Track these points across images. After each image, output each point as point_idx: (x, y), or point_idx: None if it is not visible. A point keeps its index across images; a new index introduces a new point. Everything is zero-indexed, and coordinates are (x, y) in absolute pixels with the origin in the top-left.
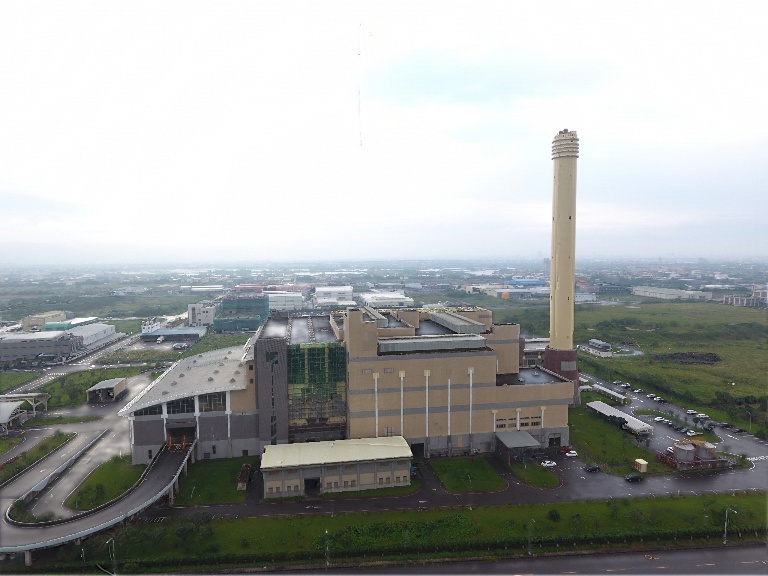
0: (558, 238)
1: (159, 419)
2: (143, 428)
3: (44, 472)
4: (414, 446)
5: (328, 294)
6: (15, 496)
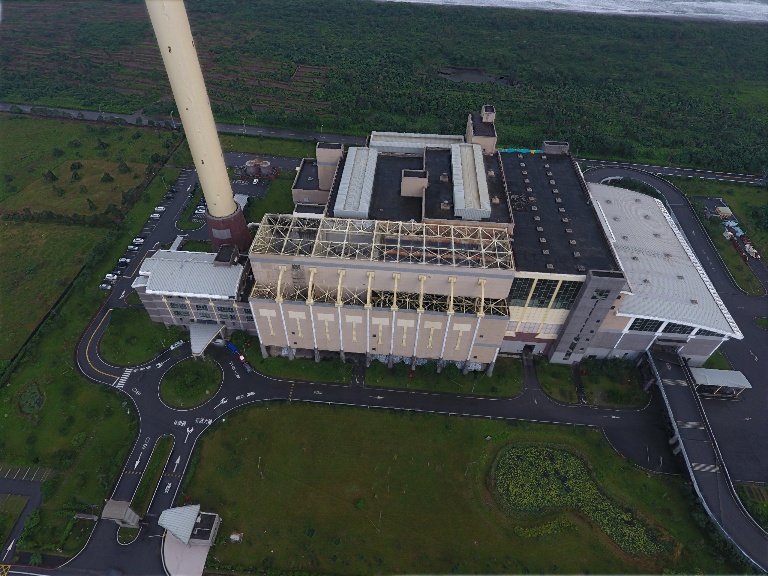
0: None
1: None
2: None
3: (690, 230)
4: None
5: None
6: (675, 207)
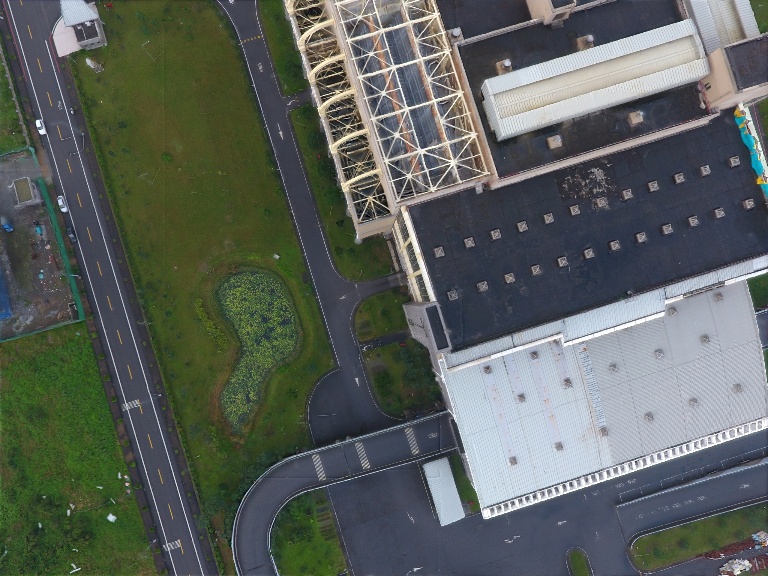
0: None
1: None
2: None
3: (750, 480)
4: None
5: None
6: None
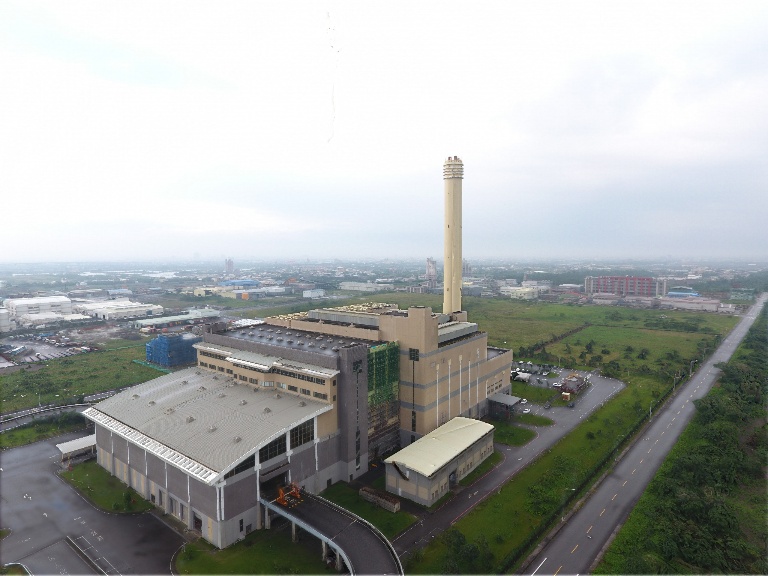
0: (454, 242)
1: (251, 474)
2: (234, 493)
3: None
4: None
5: (35, 308)
6: None
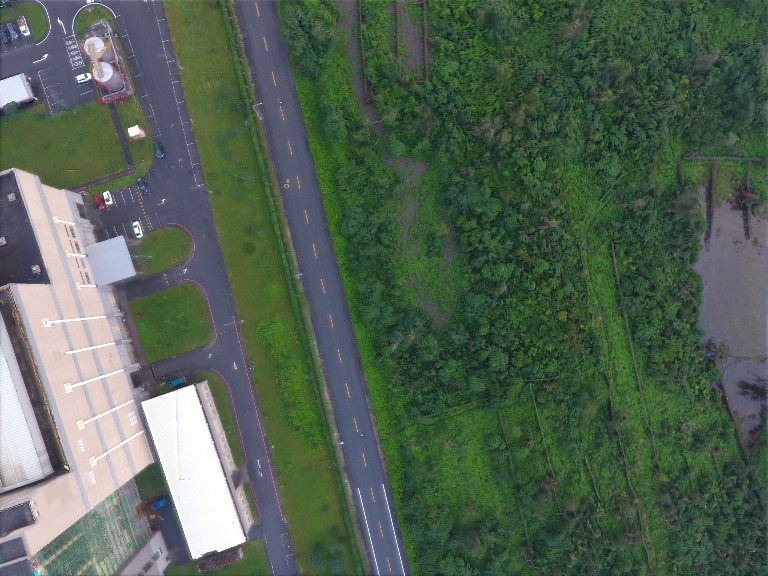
0: None
1: None
2: None
3: None
4: (133, 384)
5: None
6: None
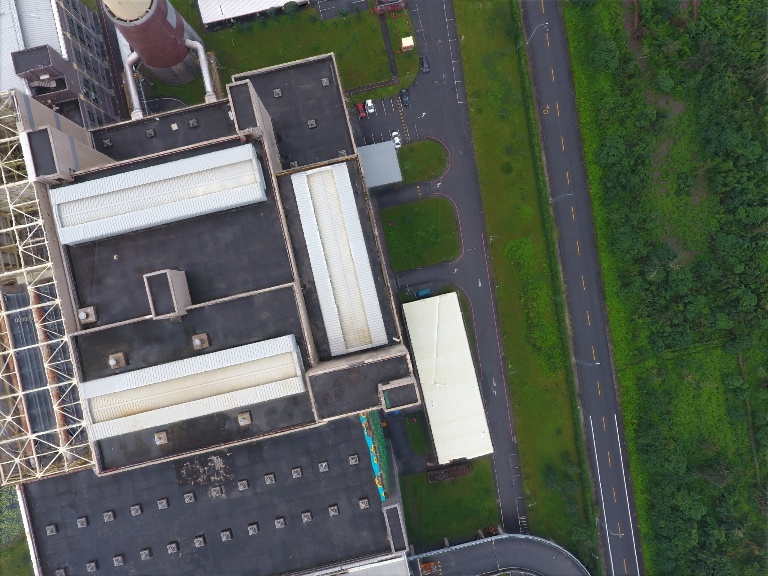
0: None
1: None
2: None
3: None
4: None
5: None
6: None
